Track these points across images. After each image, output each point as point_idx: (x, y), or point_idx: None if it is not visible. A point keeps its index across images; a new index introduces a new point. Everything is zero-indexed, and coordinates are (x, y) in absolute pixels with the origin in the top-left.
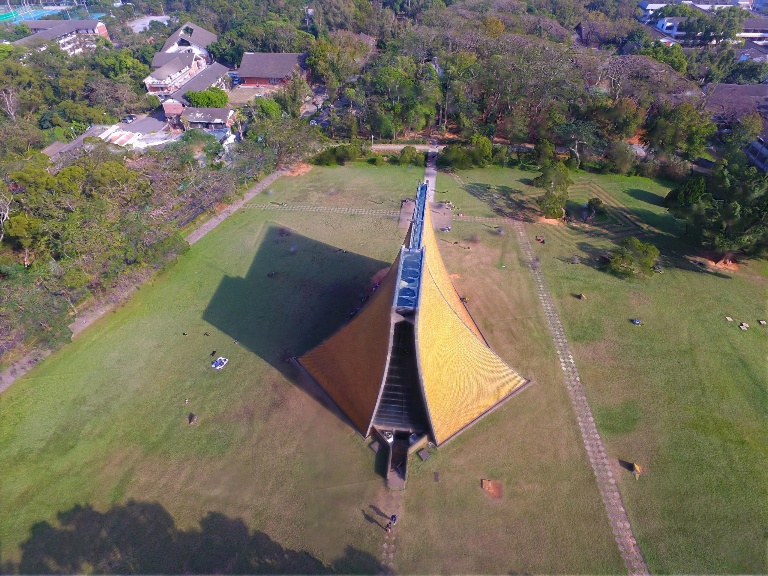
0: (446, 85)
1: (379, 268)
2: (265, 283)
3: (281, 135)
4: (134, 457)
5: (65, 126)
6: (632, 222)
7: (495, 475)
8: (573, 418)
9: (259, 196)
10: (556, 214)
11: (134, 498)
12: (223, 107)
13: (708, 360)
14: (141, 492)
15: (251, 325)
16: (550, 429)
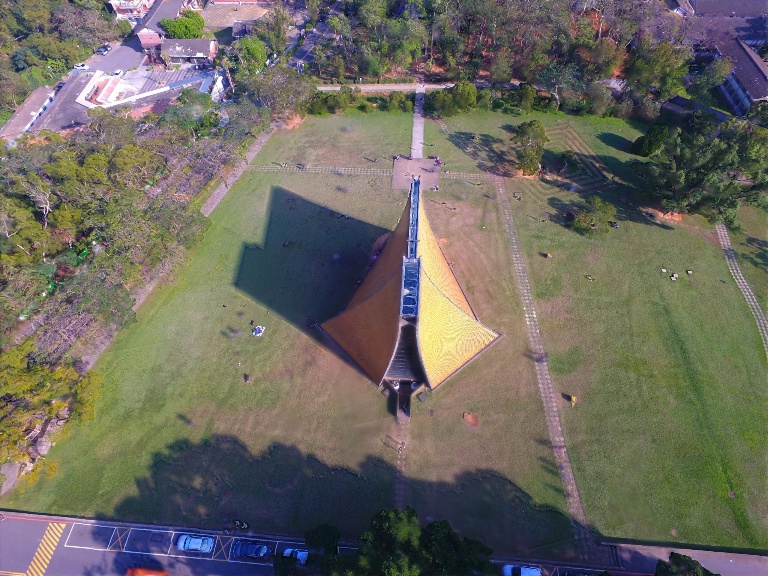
0: (431, 10)
1: (378, 235)
2: (282, 253)
3: (274, 91)
4: (211, 410)
5: (41, 65)
6: (600, 172)
7: (473, 409)
8: (532, 363)
9: (260, 155)
10: (532, 172)
11: (219, 440)
12: (201, 35)
13: (640, 309)
14: (223, 435)
15: (277, 295)
16: (514, 373)
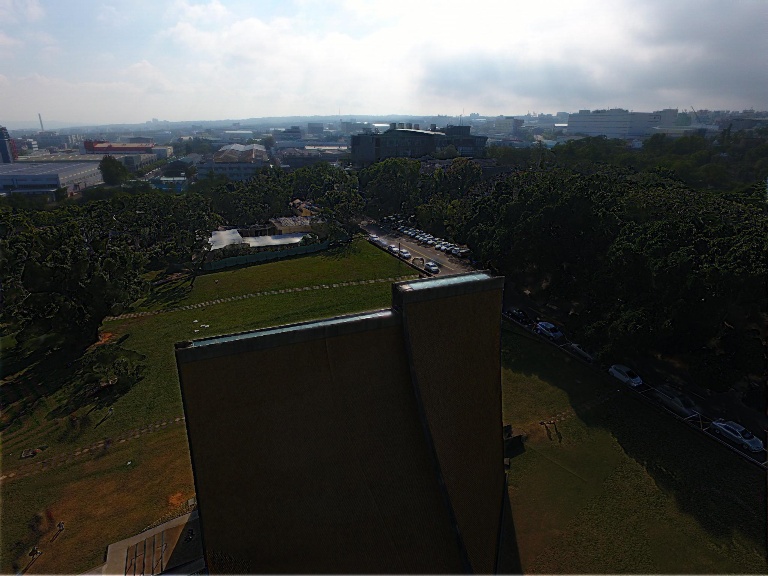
0: None
1: None
2: None
3: None
4: None
5: None
6: None
7: None
8: None
9: None
10: None
11: None
12: None
13: None
14: None
15: None
16: None
